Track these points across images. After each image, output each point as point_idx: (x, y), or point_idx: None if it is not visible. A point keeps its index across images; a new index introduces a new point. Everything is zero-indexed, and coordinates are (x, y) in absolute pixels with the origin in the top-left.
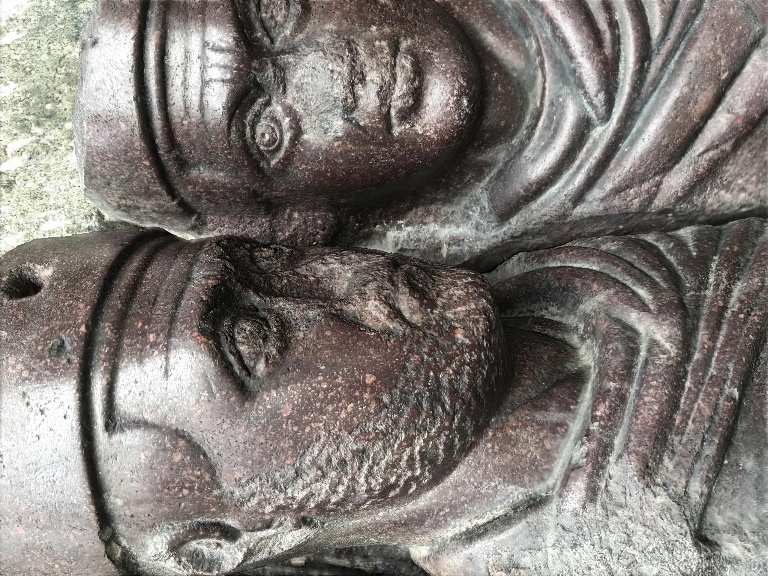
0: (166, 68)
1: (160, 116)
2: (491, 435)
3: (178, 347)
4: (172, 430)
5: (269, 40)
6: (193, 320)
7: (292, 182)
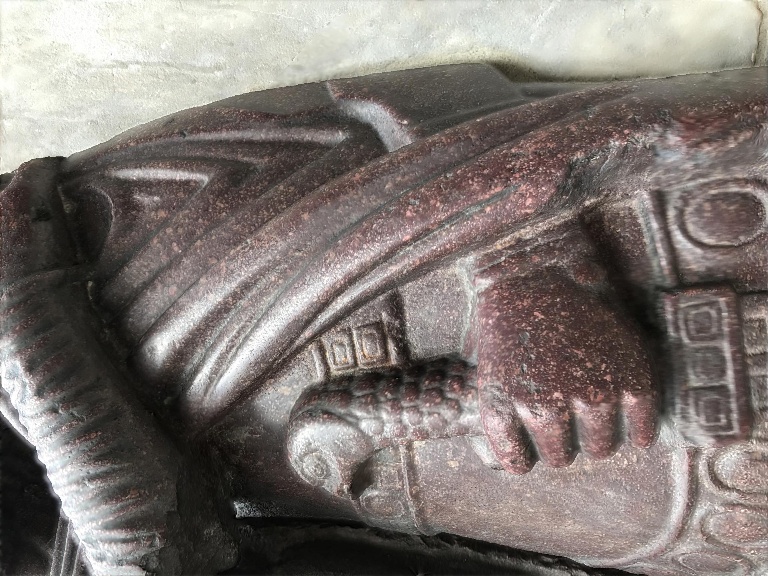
0: None
1: None
2: None
3: None
4: None
5: None
6: None
7: None
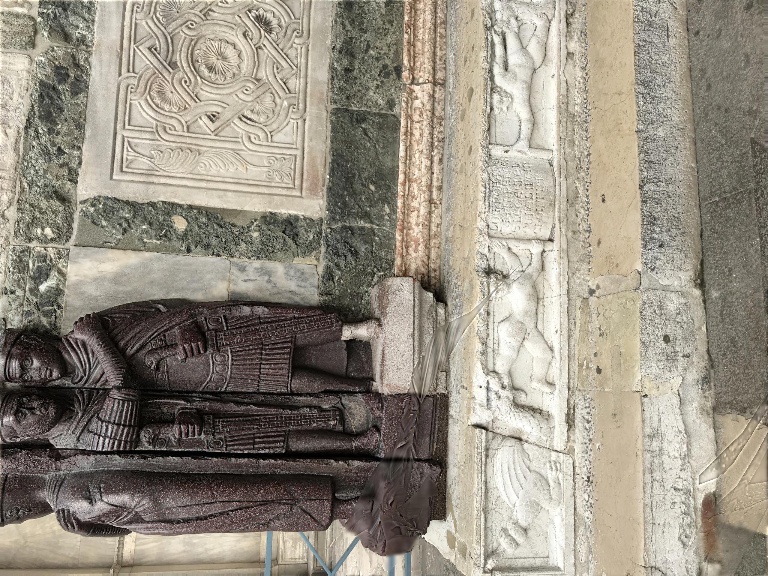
0: (9, 371)
1: (8, 376)
2: (57, 426)
3: (11, 417)
4: (10, 426)
5: (26, 367)
6: (13, 414)
7: (32, 381)
